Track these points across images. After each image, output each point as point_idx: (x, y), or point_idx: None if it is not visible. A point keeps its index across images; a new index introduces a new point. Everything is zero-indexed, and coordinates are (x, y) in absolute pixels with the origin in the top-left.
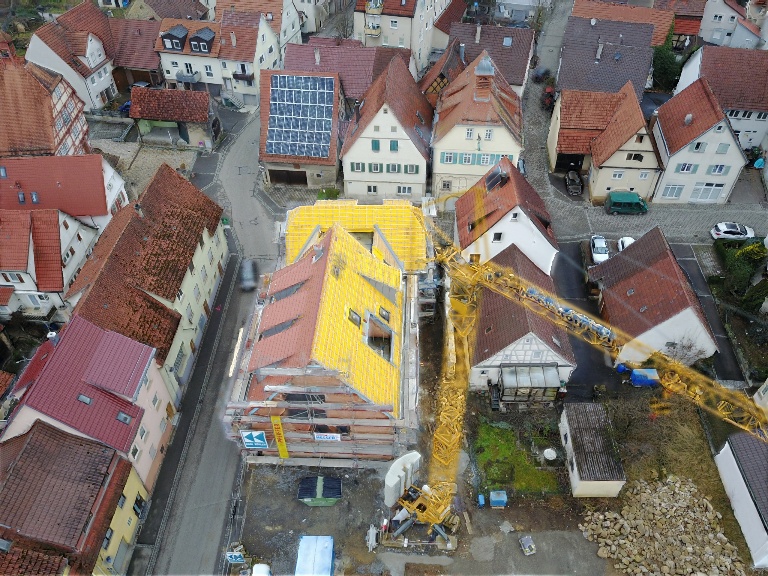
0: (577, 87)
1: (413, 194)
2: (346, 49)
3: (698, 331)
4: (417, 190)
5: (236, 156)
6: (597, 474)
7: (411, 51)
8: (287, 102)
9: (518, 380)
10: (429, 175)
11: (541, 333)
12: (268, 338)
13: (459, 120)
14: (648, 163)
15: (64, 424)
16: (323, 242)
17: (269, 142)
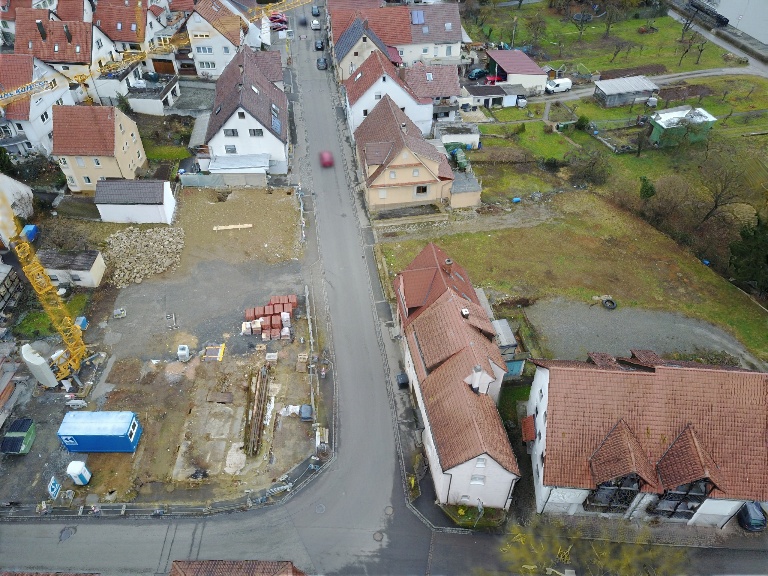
0: None
1: None
2: None
3: (14, 184)
4: None
5: None
6: (89, 262)
7: None
8: None
9: None
10: None
11: None
12: None
13: None
14: None
15: None
16: None
17: None
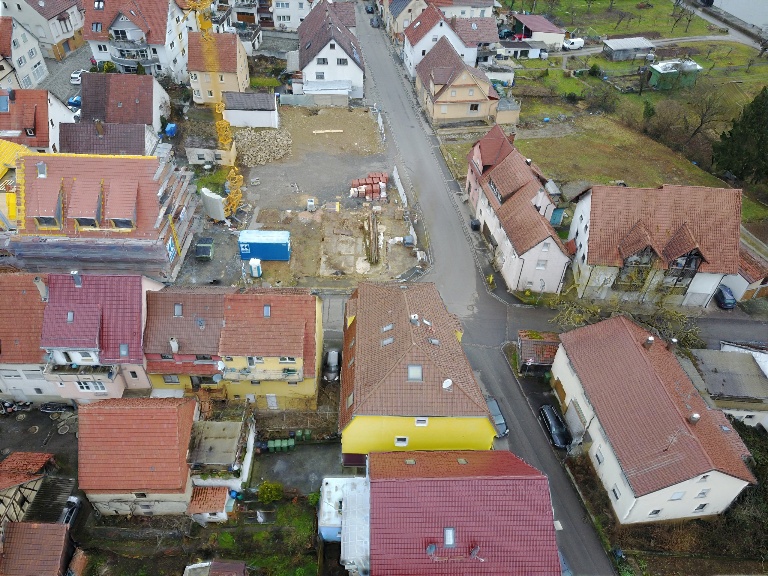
0: None
1: None
2: None
3: (161, 90)
4: None
5: None
6: (229, 145)
7: None
8: None
9: None
10: None
11: None
12: (108, 205)
13: None
14: (6, 70)
15: None
16: (31, 165)
17: None
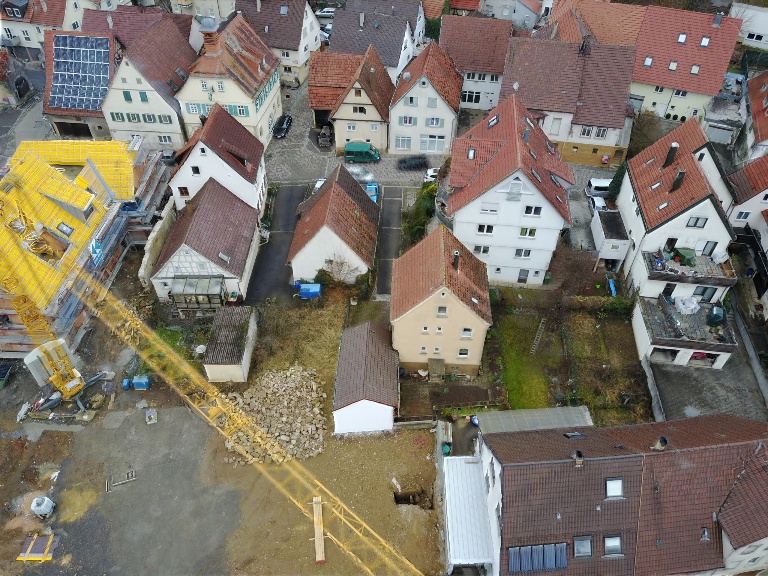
0: (345, 52)
1: (174, 143)
2: (136, 14)
3: (343, 248)
4: (176, 139)
5: (38, 112)
6: (219, 359)
7: (193, 17)
8: (69, 60)
9: (185, 288)
10: (183, 125)
11: (202, 247)
12: None
13: (192, 73)
14: (373, 116)
15: None
16: None
17: (52, 96)
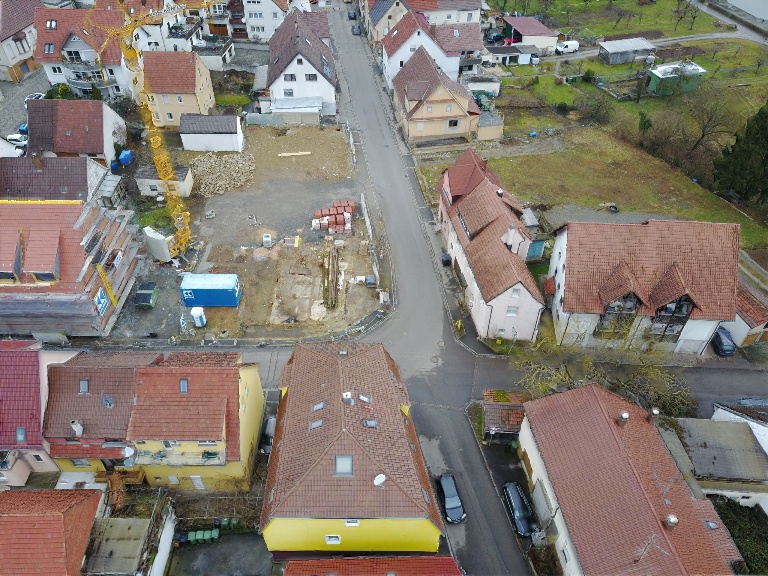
0: None
1: None
2: None
3: (114, 115)
4: None
5: None
6: (183, 175)
7: None
8: None
9: (108, 191)
10: None
11: None
12: (27, 257)
13: None
14: None
15: (60, 351)
16: None
17: None
